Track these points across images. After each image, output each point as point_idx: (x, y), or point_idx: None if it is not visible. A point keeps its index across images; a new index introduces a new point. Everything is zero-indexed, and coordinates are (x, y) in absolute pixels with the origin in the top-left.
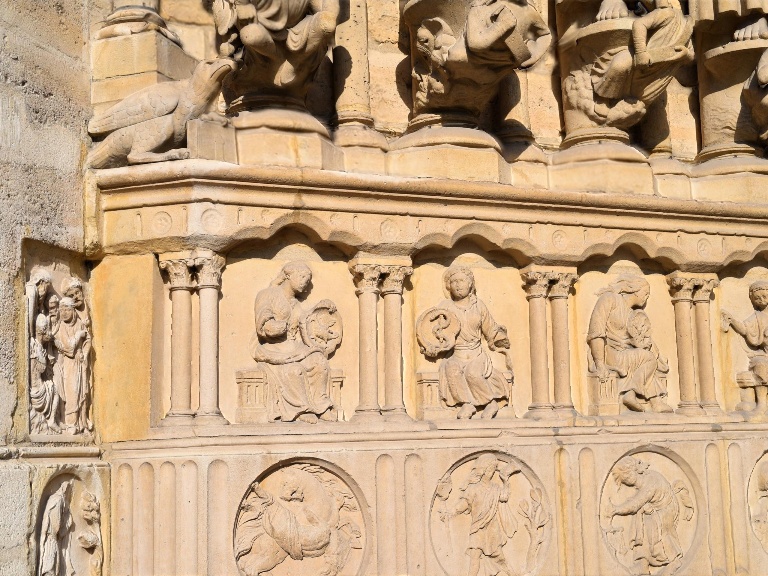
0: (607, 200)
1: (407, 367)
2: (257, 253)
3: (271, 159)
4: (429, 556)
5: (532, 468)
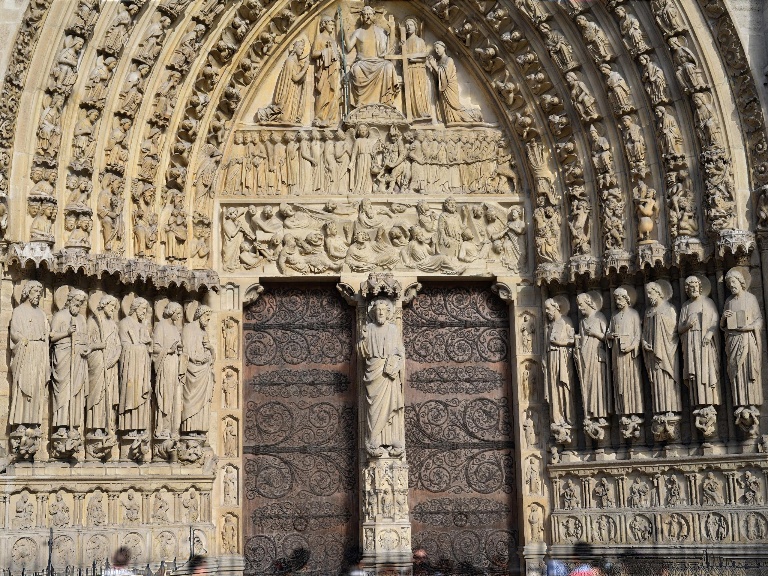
0: (94, 478)
1: (47, 517)
2: (17, 493)
3: (23, 474)
4: None
5: (73, 539)
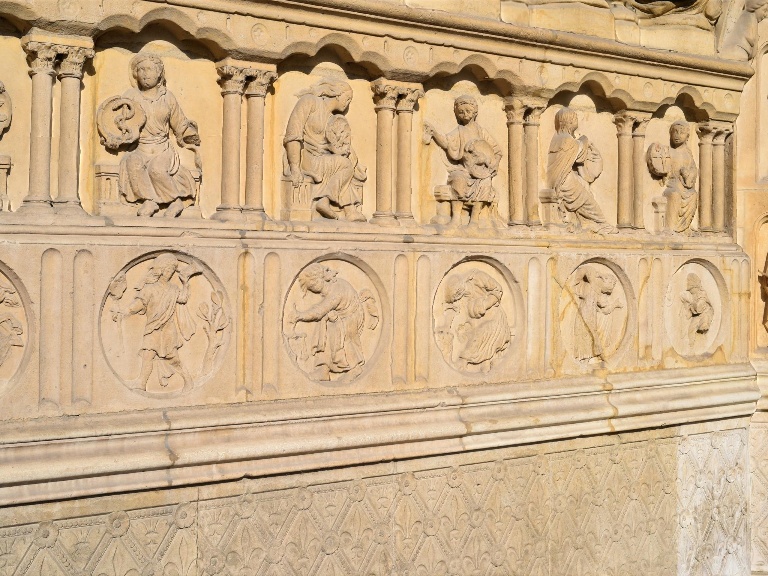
0: None
1: (85, 158)
2: None
3: None
4: (97, 356)
5: (214, 270)
